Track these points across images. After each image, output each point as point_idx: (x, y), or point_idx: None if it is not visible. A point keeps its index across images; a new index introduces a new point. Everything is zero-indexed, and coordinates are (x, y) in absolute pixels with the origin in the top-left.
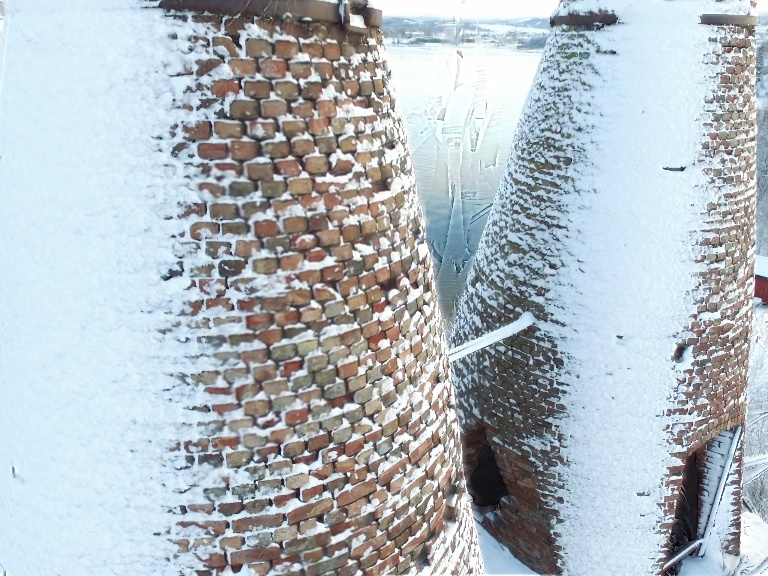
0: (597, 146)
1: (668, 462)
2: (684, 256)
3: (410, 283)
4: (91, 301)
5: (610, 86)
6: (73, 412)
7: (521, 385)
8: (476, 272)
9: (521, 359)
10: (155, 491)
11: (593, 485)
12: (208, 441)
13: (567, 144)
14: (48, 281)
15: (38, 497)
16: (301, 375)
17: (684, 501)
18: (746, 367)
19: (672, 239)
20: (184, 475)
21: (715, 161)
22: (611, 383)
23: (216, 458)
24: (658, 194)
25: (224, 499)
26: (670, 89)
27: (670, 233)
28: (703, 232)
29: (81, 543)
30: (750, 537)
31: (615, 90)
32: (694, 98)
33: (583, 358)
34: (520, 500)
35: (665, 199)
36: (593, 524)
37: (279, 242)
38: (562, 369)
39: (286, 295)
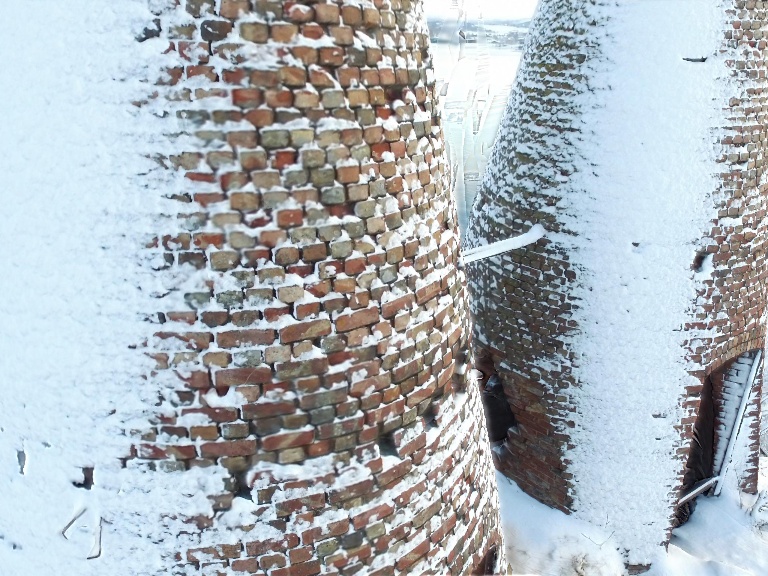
0: (612, 39)
1: (686, 381)
2: (705, 155)
3: (417, 101)
4: (56, 69)
5: None
6: (37, 205)
7: (530, 303)
8: (482, 194)
9: (530, 275)
10: (130, 295)
11: (606, 406)
12: (189, 237)
13: (580, 40)
14: (8, 50)
15: (0, 314)
16: (295, 169)
17: (697, 447)
18: (767, 286)
19: (692, 136)
20: (162, 276)
21: (738, 52)
22: (626, 294)
23: (198, 257)
24: (678, 87)
25: (208, 307)
26: None
27: (690, 129)
28: (725, 129)
29: (47, 360)
30: (767, 478)
31: None
32: None
33: (596, 269)
34: (529, 428)
35: (685, 92)
36: (606, 449)
37: (270, 7)
38: (574, 282)
39: (278, 71)
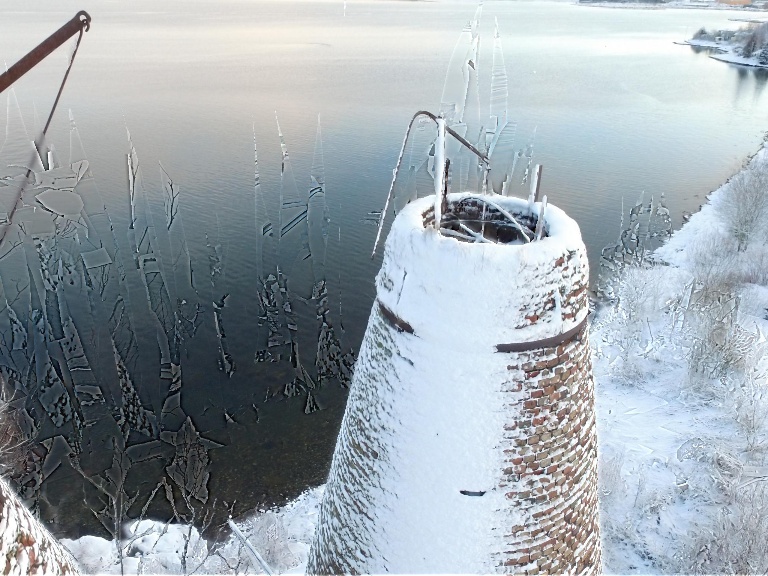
0: (397, 453)
1: None
2: None
3: None
4: None
5: (407, 397)
6: None
7: None
8: None
9: None
10: None
11: None
12: None
13: (374, 437)
14: None
15: None
16: None
17: None
18: None
19: (472, 561)
20: None
21: (520, 485)
22: None
23: None
24: (455, 517)
25: None
26: (463, 418)
27: (469, 555)
28: (508, 553)
29: None
30: None
31: (411, 404)
32: (491, 427)
33: None
34: None
35: (462, 523)
36: None
37: None
38: None
39: None
